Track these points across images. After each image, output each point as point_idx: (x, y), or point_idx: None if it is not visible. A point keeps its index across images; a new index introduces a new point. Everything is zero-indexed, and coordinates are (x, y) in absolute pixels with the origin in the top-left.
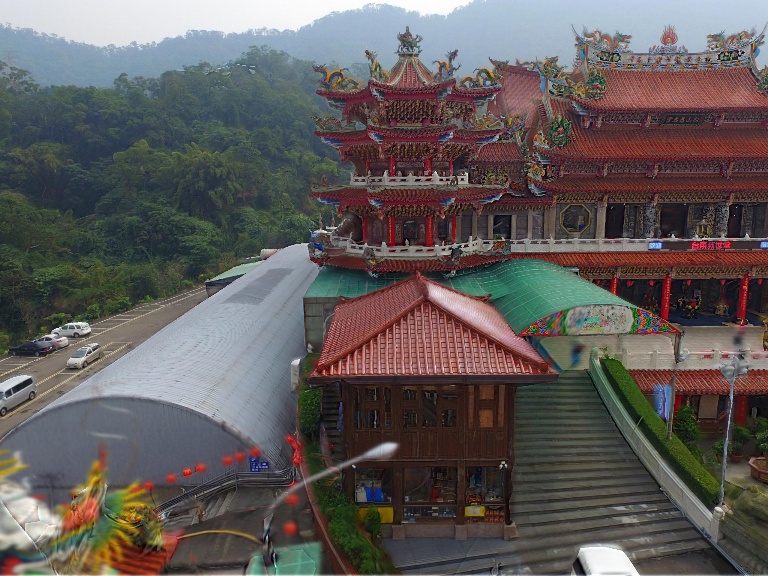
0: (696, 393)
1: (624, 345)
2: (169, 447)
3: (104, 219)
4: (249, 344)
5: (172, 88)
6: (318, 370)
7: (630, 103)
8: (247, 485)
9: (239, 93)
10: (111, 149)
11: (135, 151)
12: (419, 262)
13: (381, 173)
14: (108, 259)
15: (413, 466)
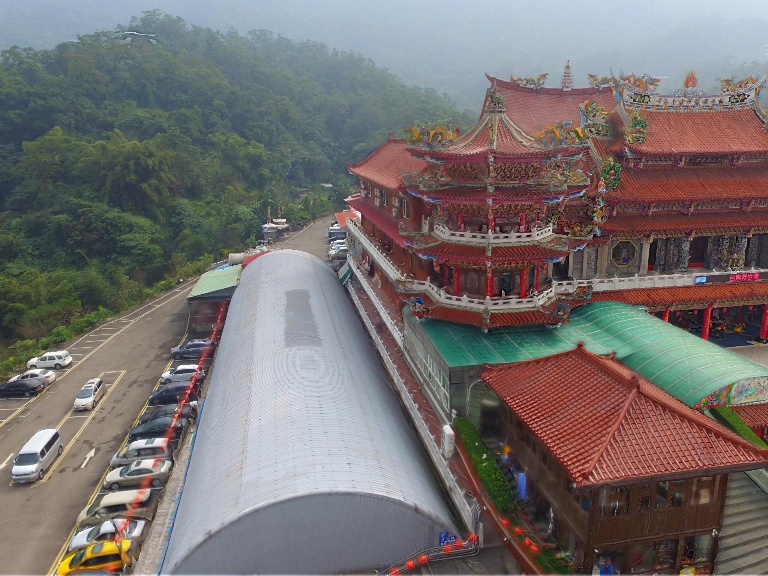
0: None
1: None
2: (364, 534)
3: (21, 217)
4: (358, 401)
5: (77, 65)
6: (586, 477)
7: (669, 146)
8: (437, 559)
9: (150, 70)
10: (11, 134)
11: (51, 140)
12: (522, 314)
13: (477, 227)
14: (37, 264)
15: (643, 543)
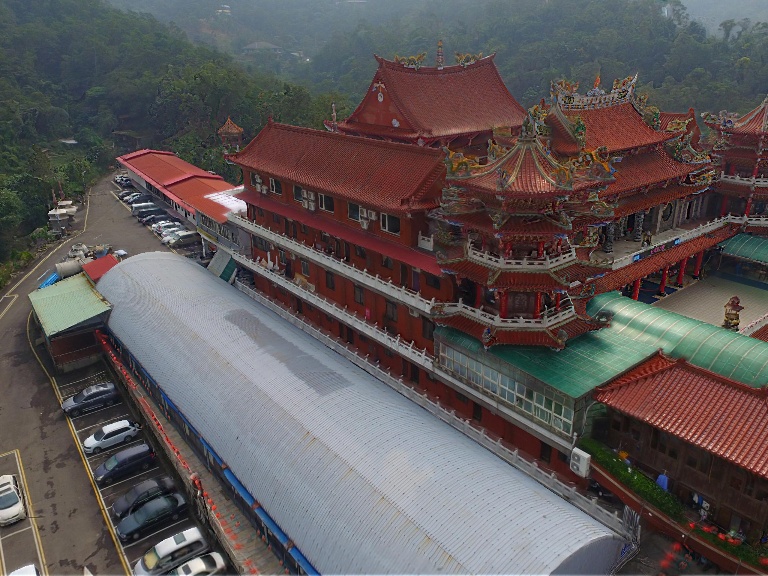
0: None
1: None
2: (584, 575)
3: None
4: (457, 440)
5: None
6: None
7: None
8: (620, 568)
9: None
10: None
11: None
12: (570, 325)
13: (527, 253)
14: None
15: None
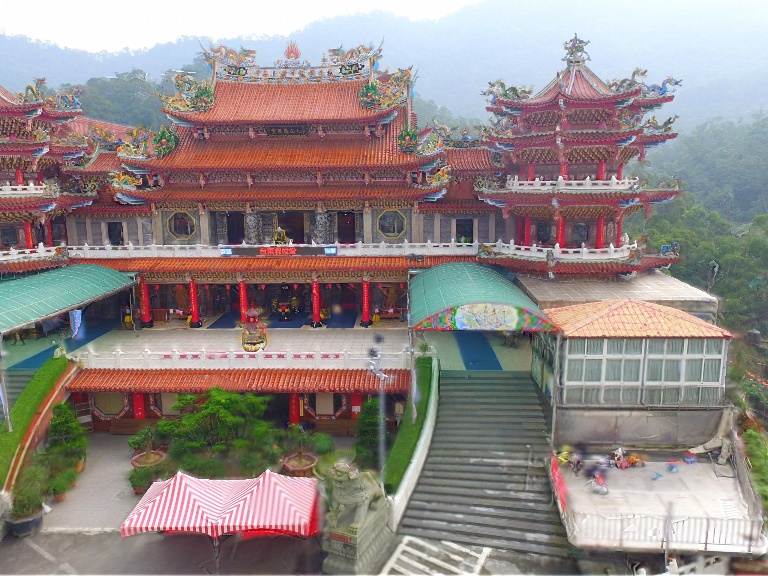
0: (131, 391)
1: (157, 346)
2: None
3: None
4: None
5: (85, 95)
6: None
7: (231, 115)
8: None
9: (158, 99)
10: None
11: None
12: None
13: None
14: None
15: None
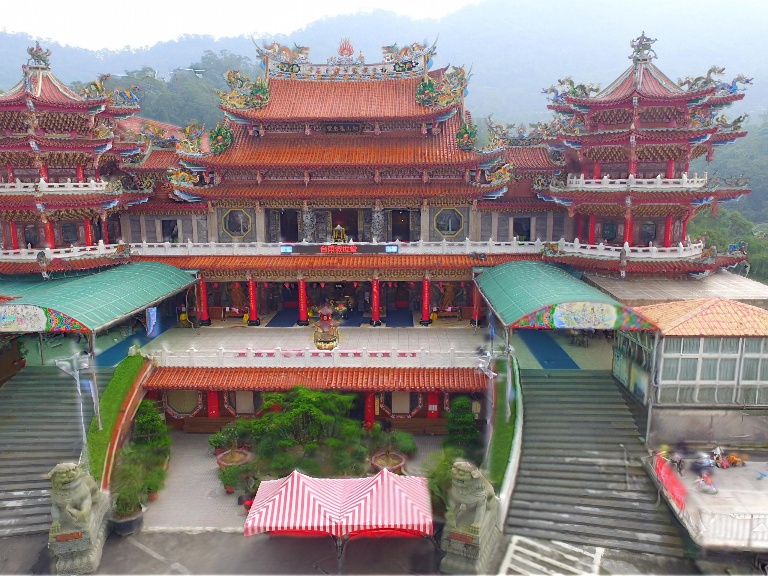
0: (208, 389)
1: (222, 344)
2: None
3: None
4: None
5: None
6: None
7: (287, 113)
8: None
9: (170, 97)
10: None
11: None
12: (26, 264)
13: (6, 180)
14: None
15: None
